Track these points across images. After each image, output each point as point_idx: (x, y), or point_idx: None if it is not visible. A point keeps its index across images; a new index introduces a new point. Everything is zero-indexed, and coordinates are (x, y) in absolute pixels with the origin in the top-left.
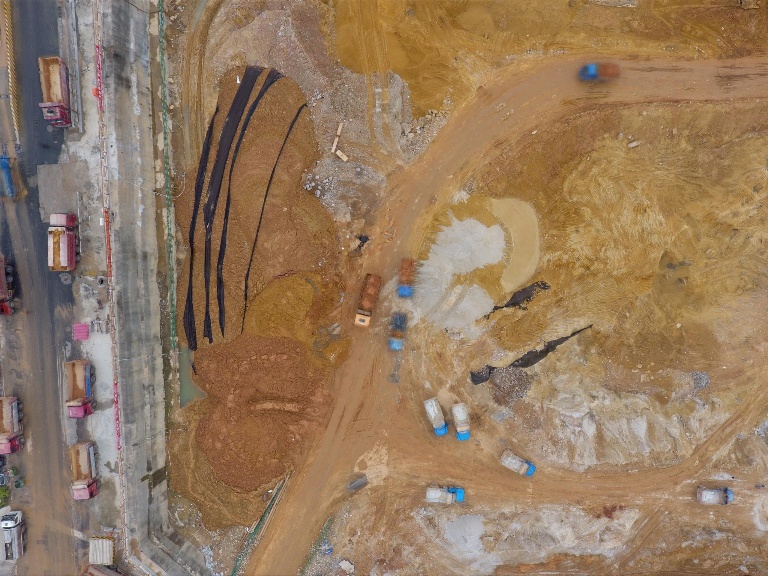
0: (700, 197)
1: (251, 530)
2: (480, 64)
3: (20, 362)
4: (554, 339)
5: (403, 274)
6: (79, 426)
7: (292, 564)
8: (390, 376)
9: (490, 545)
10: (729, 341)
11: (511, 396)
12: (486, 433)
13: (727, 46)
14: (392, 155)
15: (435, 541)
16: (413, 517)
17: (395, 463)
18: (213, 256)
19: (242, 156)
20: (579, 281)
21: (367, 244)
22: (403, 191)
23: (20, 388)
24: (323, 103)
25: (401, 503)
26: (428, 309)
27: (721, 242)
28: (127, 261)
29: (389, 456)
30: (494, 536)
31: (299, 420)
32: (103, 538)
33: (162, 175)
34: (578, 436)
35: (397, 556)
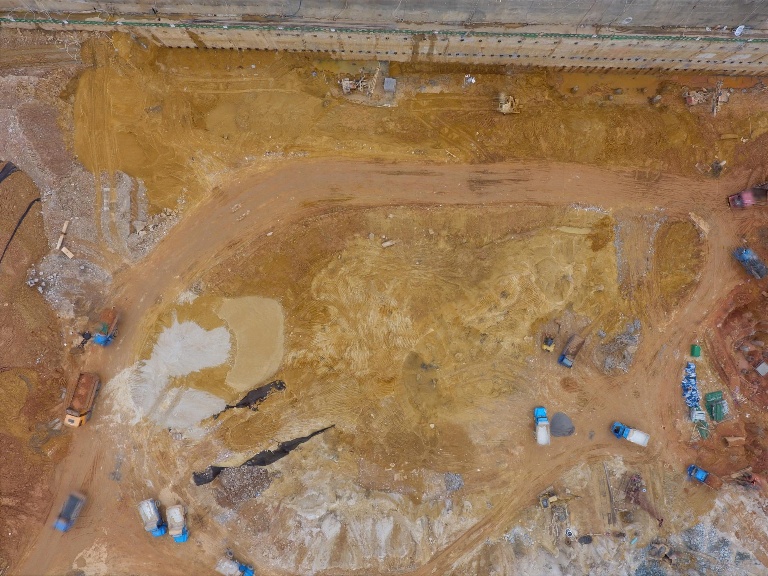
0: (456, 298)
1: None
2: (217, 165)
3: None
4: (287, 440)
5: (125, 373)
6: None
7: None
8: (111, 474)
9: None
10: (484, 443)
11: (240, 497)
12: (208, 535)
13: (480, 151)
14: (119, 254)
15: None
16: None
17: (114, 561)
18: None
19: None
20: (320, 381)
21: (90, 341)
22: (128, 290)
23: None
24: (51, 200)
25: None
26: (148, 409)
27: (472, 345)
28: None
29: (108, 554)
30: None
31: (17, 514)
32: None
33: None
34: (315, 537)
35: None
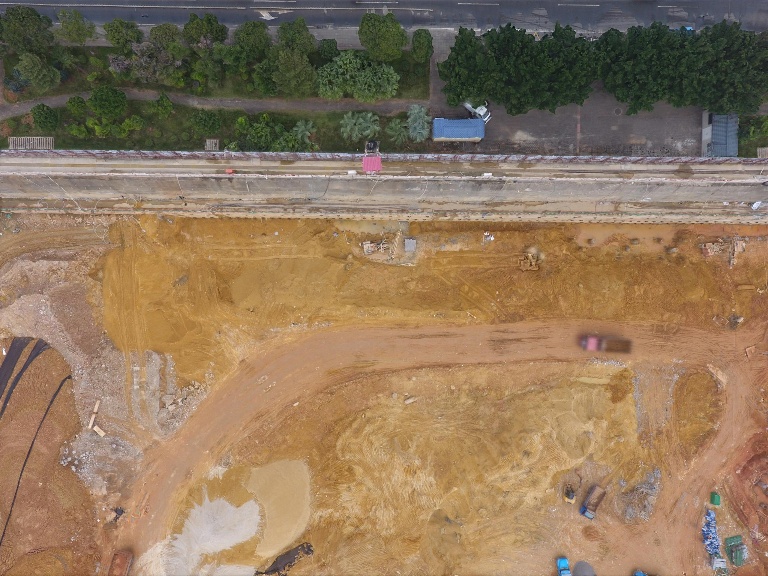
0: (478, 451)
1: None
2: (243, 338)
3: None
4: None
5: (157, 547)
6: None
7: None
8: None
9: None
10: None
11: None
12: None
13: (500, 311)
14: (149, 430)
15: None
16: None
17: None
18: None
19: (2, 429)
20: (346, 542)
21: (123, 517)
22: (159, 466)
23: None
24: (82, 380)
25: None
26: None
27: (495, 500)
28: None
29: None
30: None
31: None
32: None
33: None
34: None
35: None
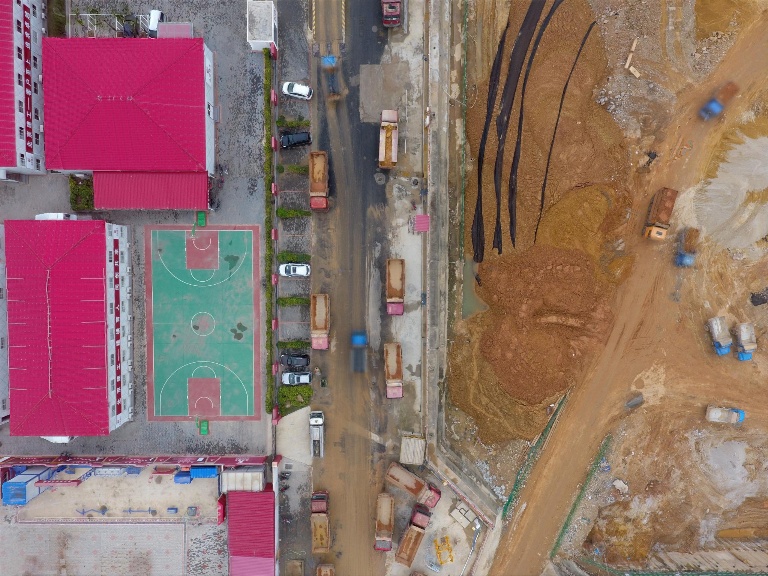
0: None
1: (533, 444)
2: None
3: (330, 261)
4: None
5: (690, 191)
6: (383, 328)
7: (571, 480)
8: (671, 294)
9: (753, 473)
10: None
11: None
12: (763, 355)
13: None
14: (683, 73)
15: (699, 466)
16: (687, 438)
17: (672, 383)
18: (505, 167)
19: (536, 69)
20: None
21: (655, 161)
22: (693, 109)
23: (328, 287)
24: (618, 19)
25: (676, 424)
26: (715, 227)
27: None
28: (439, 164)
29: (666, 375)
30: (754, 465)
31: (579, 336)
32: (415, 437)
33: (457, 86)
34: None
35: (665, 479)
